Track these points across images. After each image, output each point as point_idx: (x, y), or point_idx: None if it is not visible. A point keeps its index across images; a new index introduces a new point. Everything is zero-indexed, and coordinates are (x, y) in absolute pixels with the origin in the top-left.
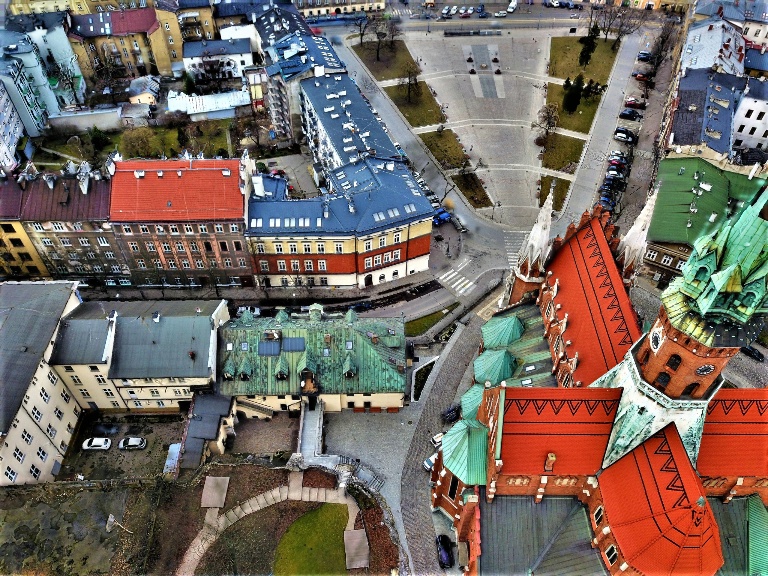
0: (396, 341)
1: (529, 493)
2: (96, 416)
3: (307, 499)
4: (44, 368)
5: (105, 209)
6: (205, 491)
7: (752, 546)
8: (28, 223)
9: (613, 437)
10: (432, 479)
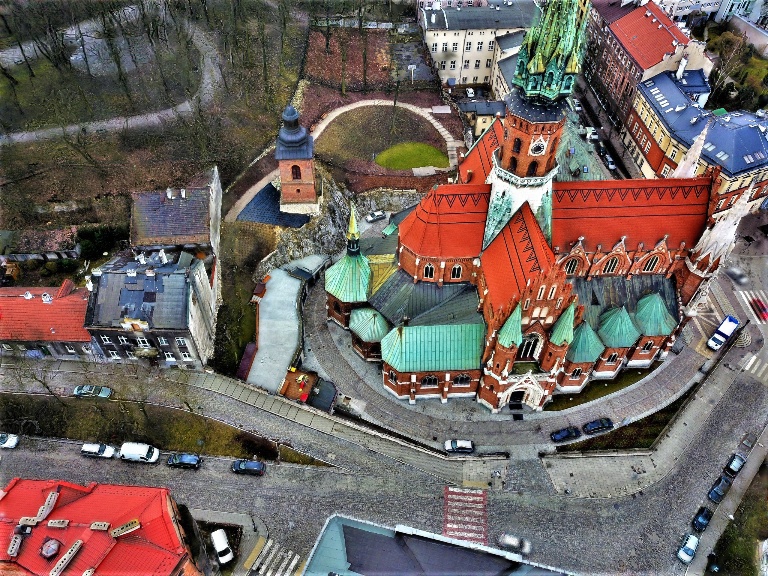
0: (575, 167)
1: None
2: (488, 90)
3: (448, 149)
4: (492, 35)
5: (615, 19)
6: (441, 106)
7: None
8: (590, 3)
9: None
10: None
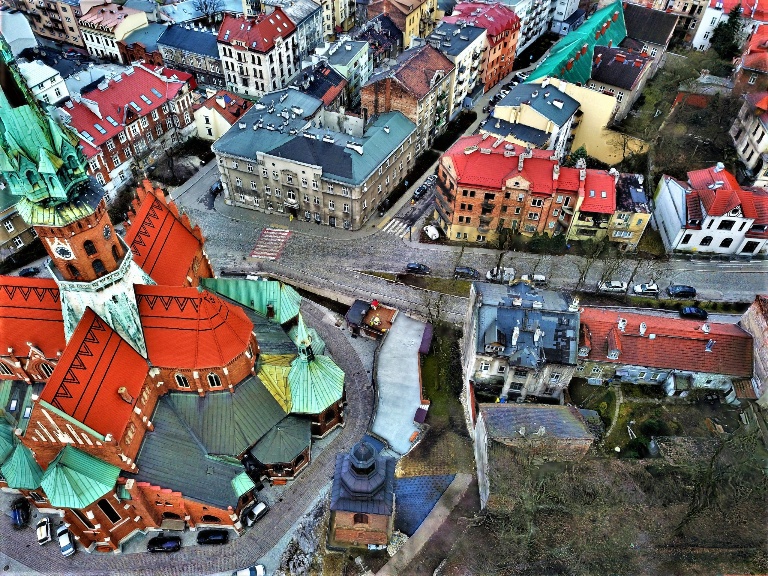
0: None
1: (143, 433)
2: None
3: None
4: None
5: None
6: None
7: (233, 297)
8: None
9: (125, 336)
10: (87, 546)
